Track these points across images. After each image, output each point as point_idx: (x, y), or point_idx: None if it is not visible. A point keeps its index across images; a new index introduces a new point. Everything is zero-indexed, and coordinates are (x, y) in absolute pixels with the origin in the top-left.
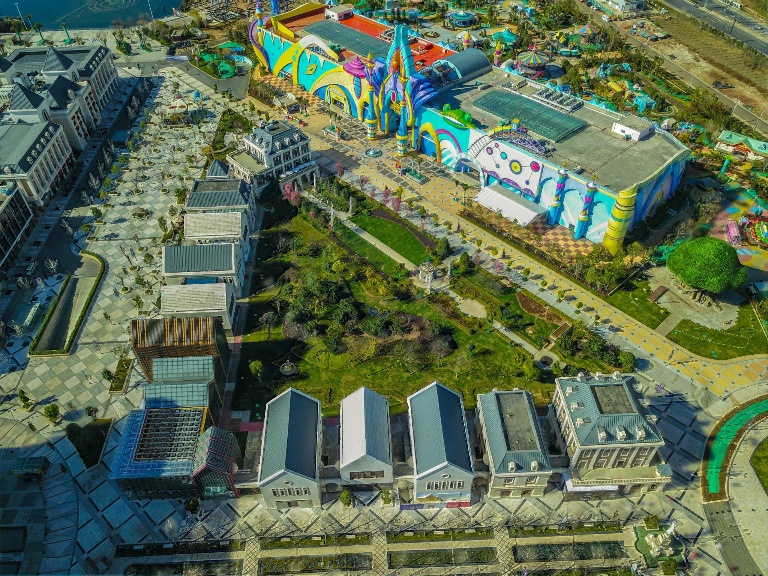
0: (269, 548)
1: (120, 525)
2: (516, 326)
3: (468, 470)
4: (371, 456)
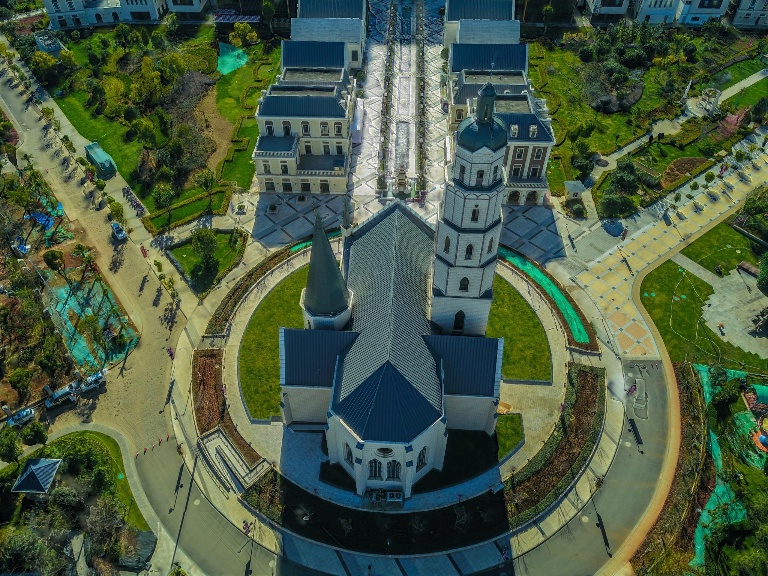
0: (417, 41)
1: (435, 3)
2: (648, 150)
3: (453, 67)
4: (460, 25)
